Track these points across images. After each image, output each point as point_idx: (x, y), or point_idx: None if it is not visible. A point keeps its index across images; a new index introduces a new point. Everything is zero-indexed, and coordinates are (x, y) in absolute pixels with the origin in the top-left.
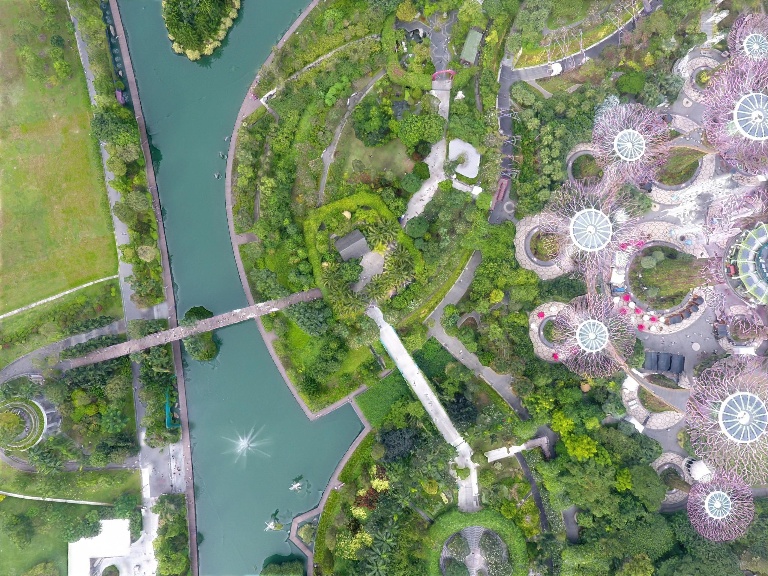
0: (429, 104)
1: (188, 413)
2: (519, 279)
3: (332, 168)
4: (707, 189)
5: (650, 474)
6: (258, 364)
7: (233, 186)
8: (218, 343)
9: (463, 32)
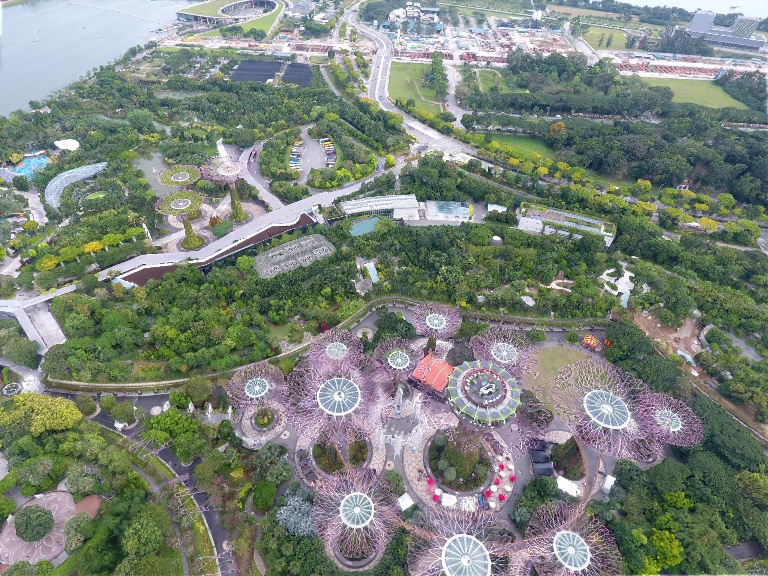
0: None
1: None
2: None
3: None
4: None
5: (661, 474)
6: None
7: None
8: None
9: None
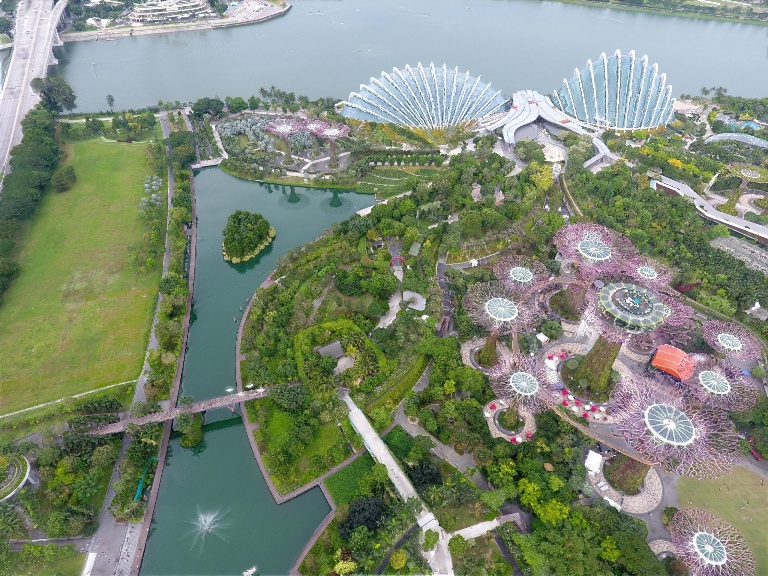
0: (387, 270)
1: (158, 496)
2: (466, 373)
3: (319, 306)
4: None
5: (634, 537)
6: (236, 453)
7: (245, 326)
8: (203, 447)
9: (408, 242)
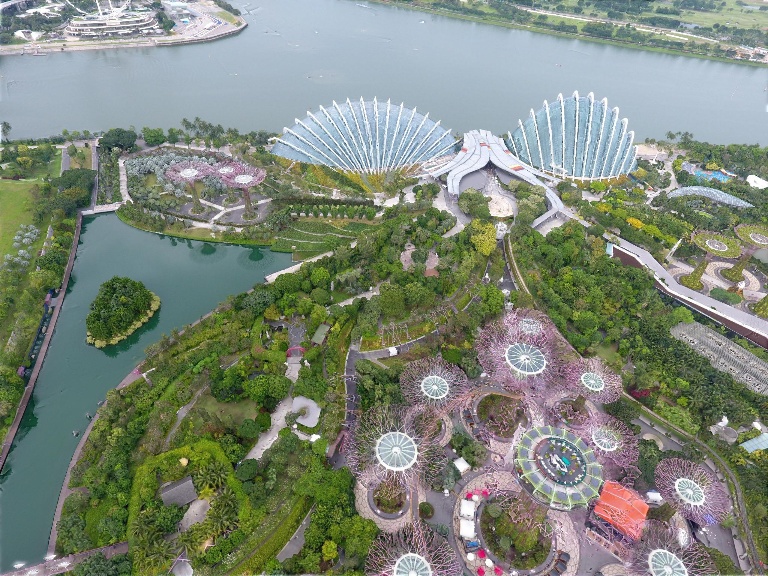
0: (276, 368)
1: None
2: (354, 528)
3: (182, 420)
4: None
5: None
6: None
7: (87, 443)
8: None
9: (313, 325)
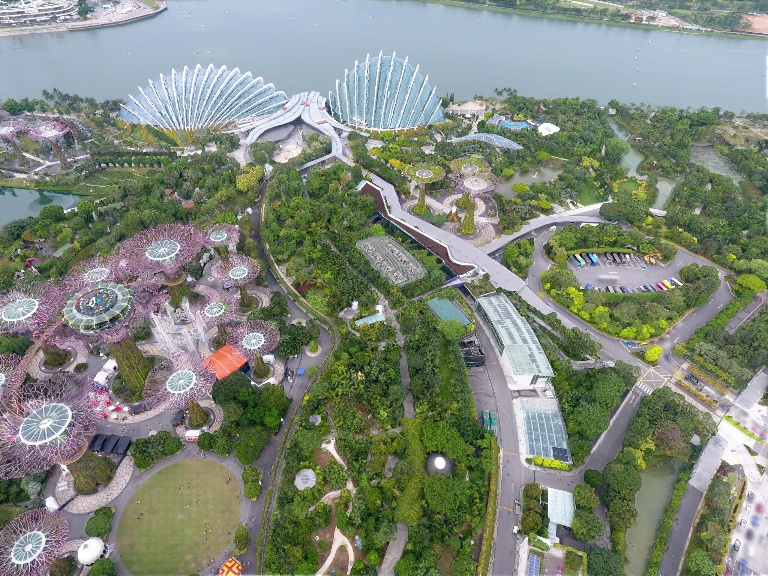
0: (2, 271)
1: None
2: None
3: None
4: (189, 316)
5: None
6: None
7: None
8: None
9: (57, 243)
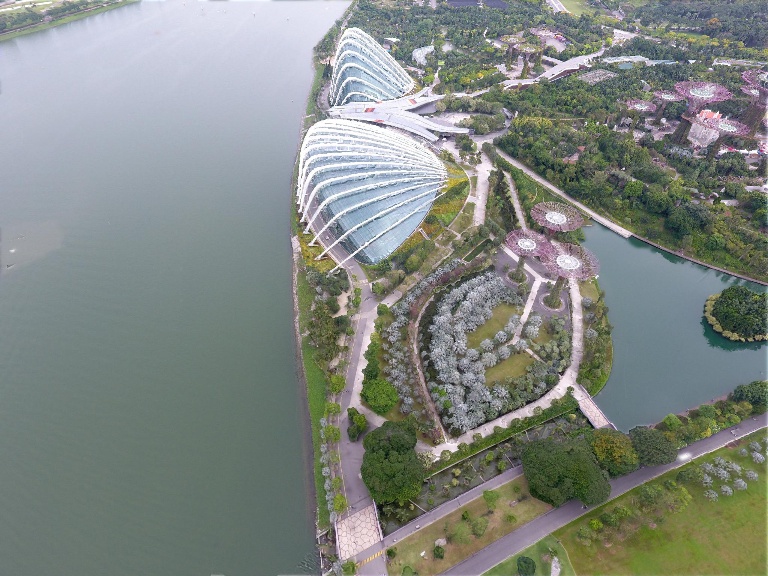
0: None
1: None
2: None
3: None
4: None
5: None
6: None
7: None
8: None
9: None
